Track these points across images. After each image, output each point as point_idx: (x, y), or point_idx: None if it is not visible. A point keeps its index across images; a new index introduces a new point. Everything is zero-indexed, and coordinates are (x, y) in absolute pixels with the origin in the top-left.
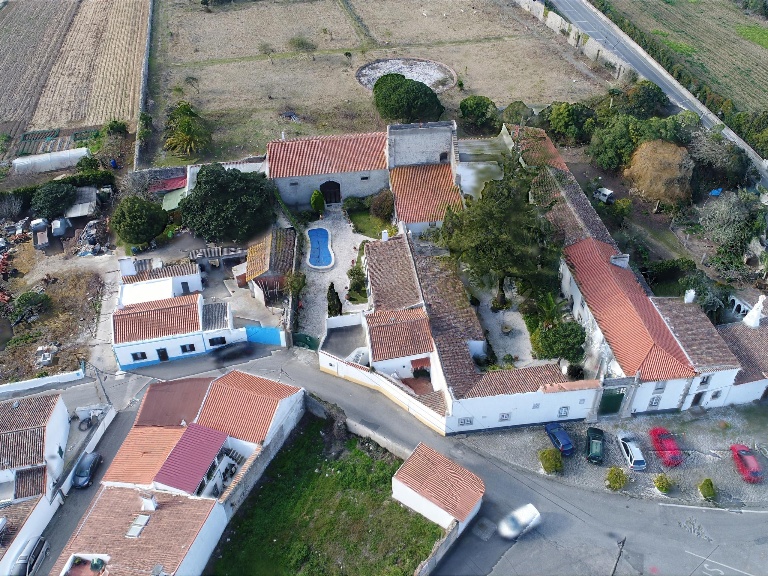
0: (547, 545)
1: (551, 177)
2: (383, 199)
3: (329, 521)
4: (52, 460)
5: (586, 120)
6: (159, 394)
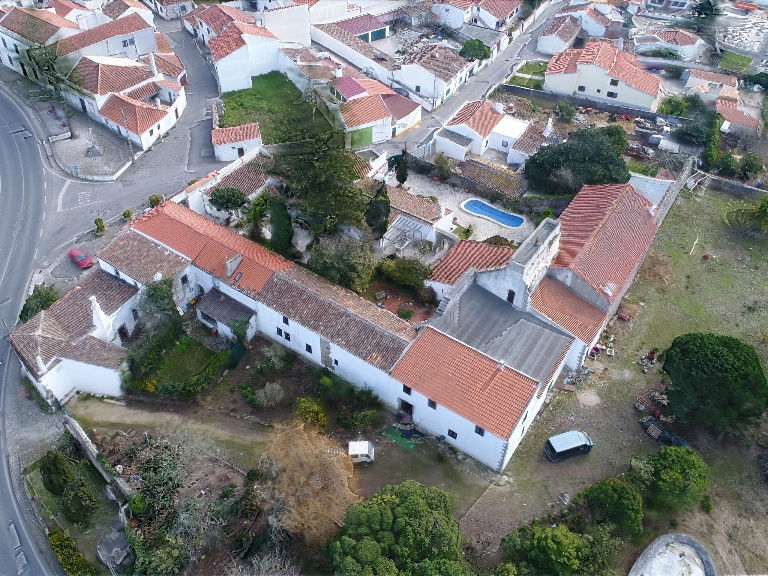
0: (173, 163)
1: (387, 328)
2: (496, 236)
3: (276, 121)
4: (409, 79)
5: (518, 568)
6: (412, 104)
